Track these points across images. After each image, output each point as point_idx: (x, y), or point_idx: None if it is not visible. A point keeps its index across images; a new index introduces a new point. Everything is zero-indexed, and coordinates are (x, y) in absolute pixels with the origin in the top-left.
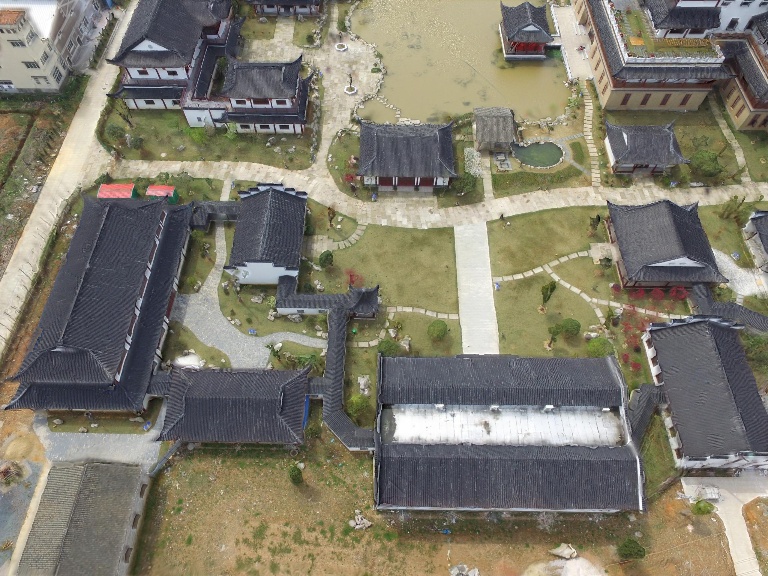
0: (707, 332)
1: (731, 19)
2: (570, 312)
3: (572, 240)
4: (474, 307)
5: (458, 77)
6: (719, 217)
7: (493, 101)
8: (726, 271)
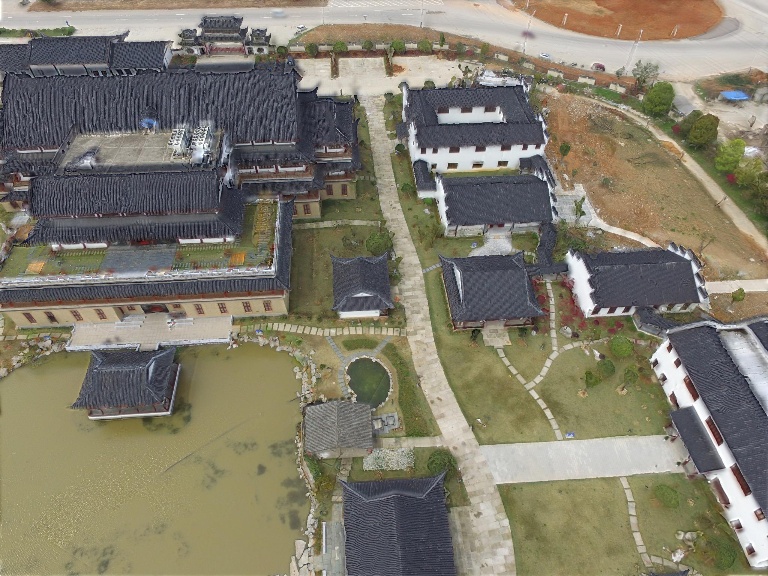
0: (597, 269)
1: (228, 182)
2: (576, 370)
3: (486, 361)
4: (604, 460)
5: (200, 482)
6: (432, 248)
7: (254, 434)
8: (490, 254)
